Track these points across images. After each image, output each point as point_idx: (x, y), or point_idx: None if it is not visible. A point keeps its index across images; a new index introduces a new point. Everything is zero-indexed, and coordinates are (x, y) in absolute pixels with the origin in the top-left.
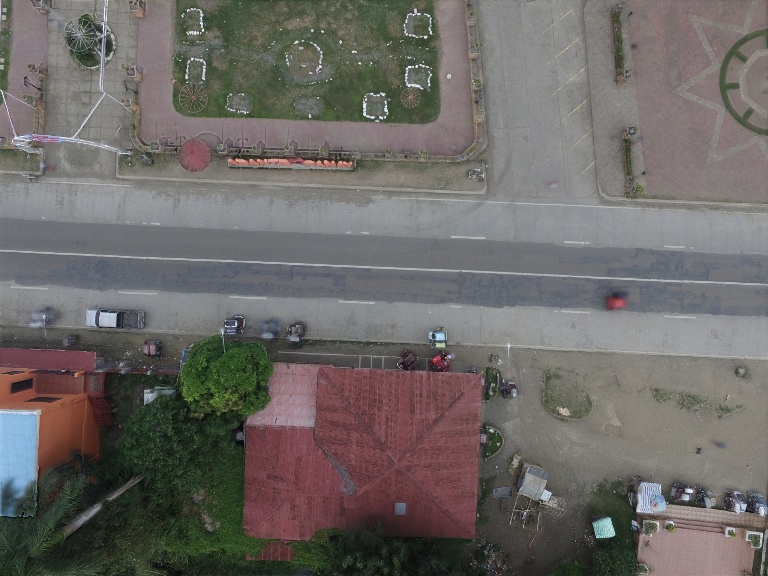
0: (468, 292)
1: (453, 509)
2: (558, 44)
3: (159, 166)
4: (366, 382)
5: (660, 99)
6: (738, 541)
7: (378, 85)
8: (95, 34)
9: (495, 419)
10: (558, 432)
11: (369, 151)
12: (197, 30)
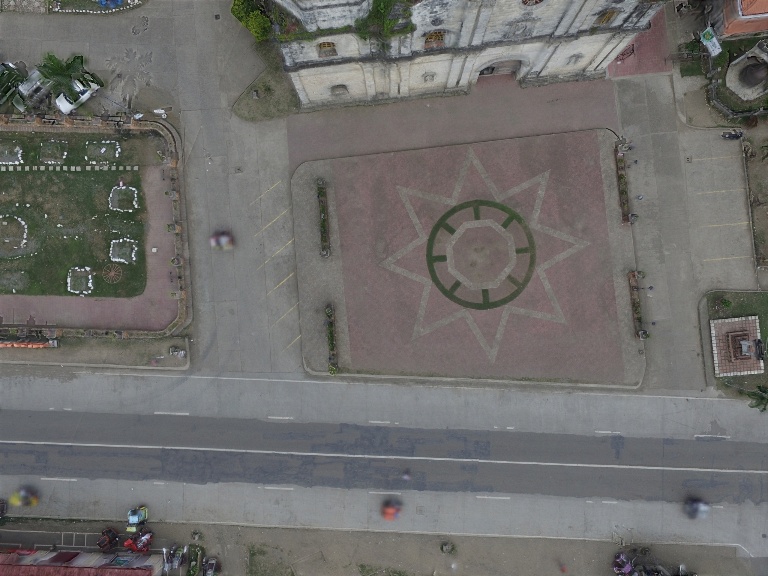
0: (171, 469)
1: None
2: (265, 216)
3: None
4: None
5: (366, 272)
6: None
7: (84, 259)
8: None
9: None
10: None
11: (74, 325)
12: None
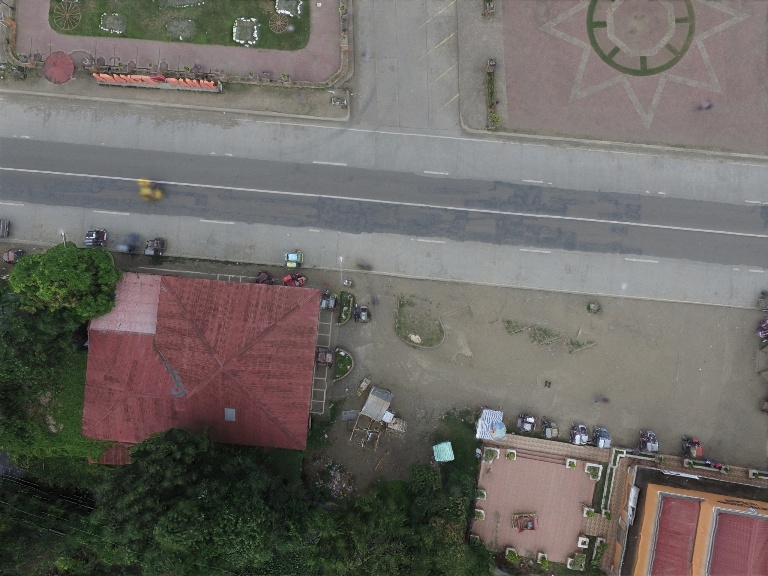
0: (327, 217)
1: (282, 418)
2: None
3: (31, 80)
4: (205, 291)
5: (526, 35)
6: (579, 473)
7: (249, 11)
8: None
9: (348, 343)
10: (410, 359)
11: (237, 75)
12: None
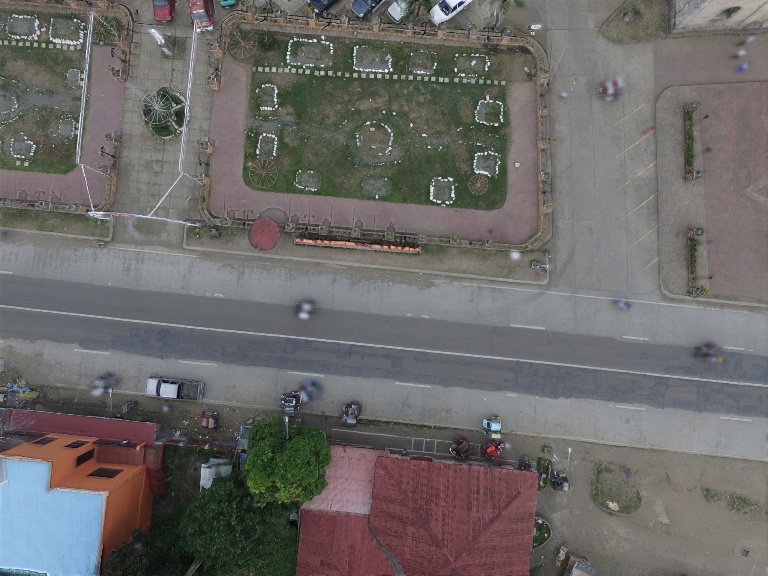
0: (524, 381)
1: None
2: (628, 138)
3: (226, 239)
4: (424, 475)
5: (728, 199)
6: None
7: (446, 169)
8: (171, 105)
9: (544, 509)
10: (606, 526)
11: (433, 235)
12: (271, 106)
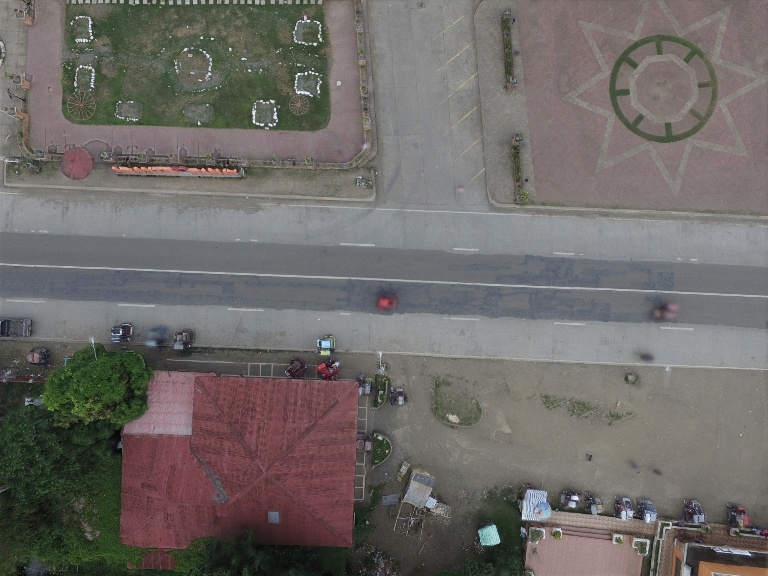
0: (357, 299)
1: (327, 517)
2: (448, 51)
3: (47, 174)
4: (241, 390)
5: (550, 106)
6: (626, 548)
7: (268, 92)
8: None
9: (385, 426)
10: (448, 439)
11: (259, 158)
12: (86, 38)
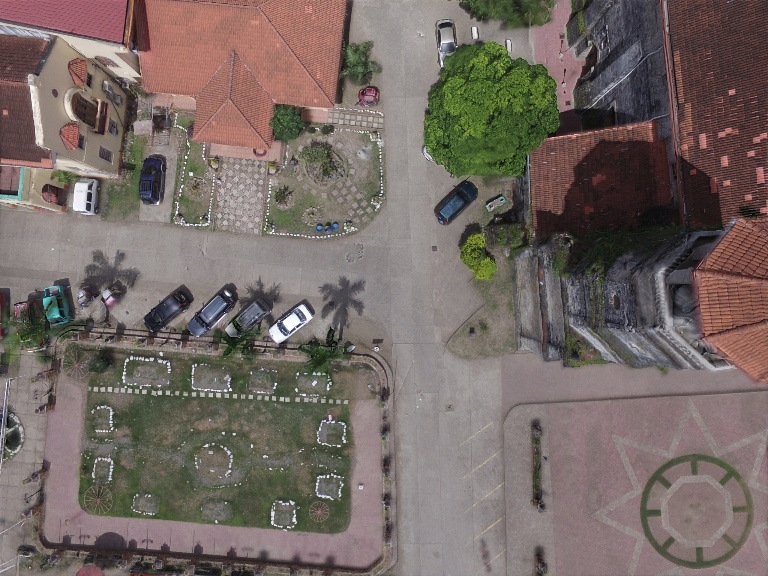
0: None
1: None
2: (475, 458)
3: (60, 569)
4: None
5: (577, 523)
6: None
7: (288, 492)
8: None
9: None
10: None
11: (275, 559)
12: (106, 429)
